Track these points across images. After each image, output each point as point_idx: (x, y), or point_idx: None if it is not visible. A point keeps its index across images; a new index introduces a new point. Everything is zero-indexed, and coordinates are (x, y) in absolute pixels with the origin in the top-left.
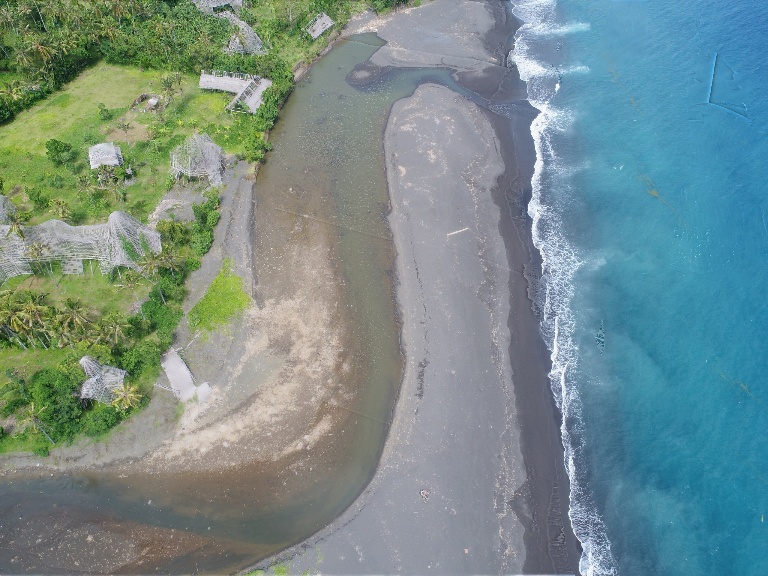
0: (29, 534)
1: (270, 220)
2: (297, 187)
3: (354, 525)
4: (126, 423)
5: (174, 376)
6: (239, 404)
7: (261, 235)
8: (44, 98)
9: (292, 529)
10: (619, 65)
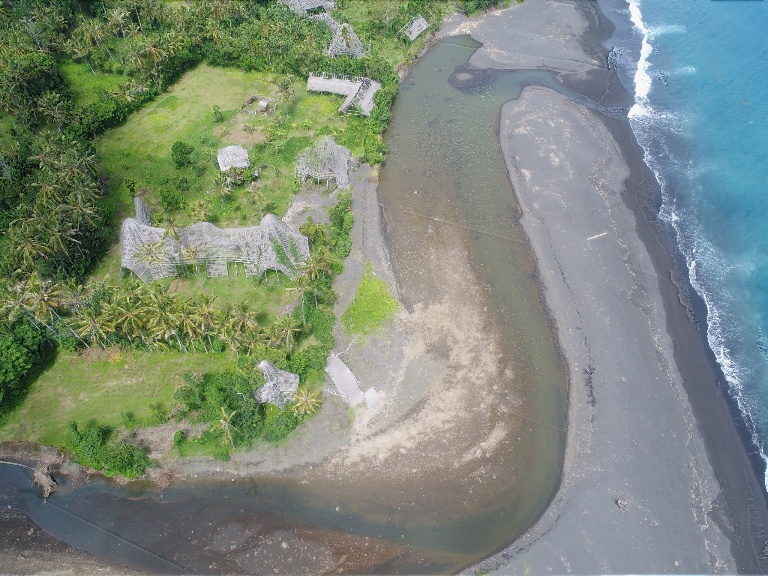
0: (222, 540)
1: (401, 223)
2: (422, 190)
3: (554, 535)
4: (302, 428)
5: (340, 381)
6: (409, 410)
7: (395, 238)
8: (152, 100)
9: (488, 538)
10: (730, 67)
